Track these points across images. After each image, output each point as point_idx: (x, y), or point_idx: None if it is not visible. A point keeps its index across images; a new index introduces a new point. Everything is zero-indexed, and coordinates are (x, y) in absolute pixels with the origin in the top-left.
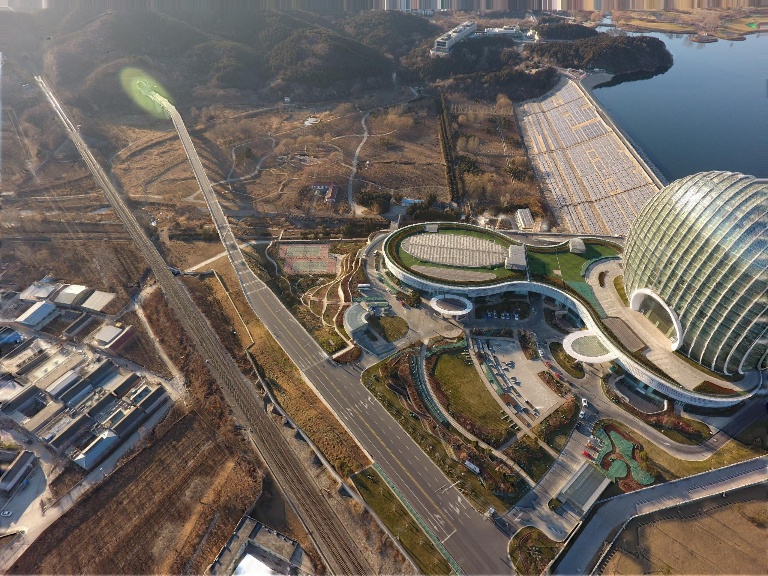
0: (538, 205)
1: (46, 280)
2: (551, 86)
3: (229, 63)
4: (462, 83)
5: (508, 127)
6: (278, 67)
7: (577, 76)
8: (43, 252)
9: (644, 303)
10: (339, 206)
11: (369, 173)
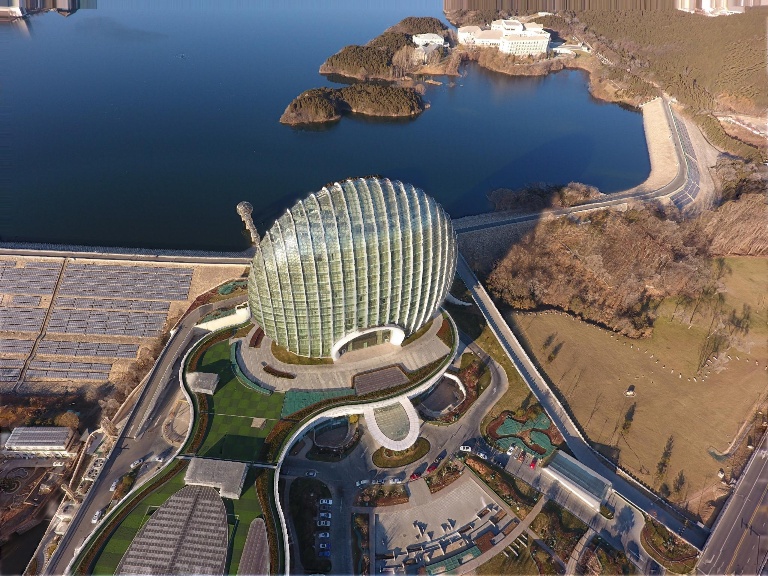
0: None
1: None
2: None
3: None
4: None
5: None
6: None
7: None
8: None
9: None
10: None
11: None
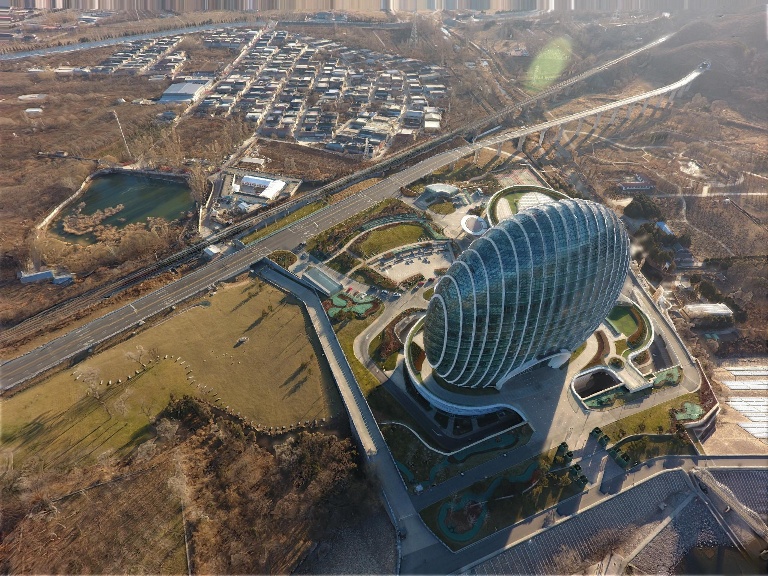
0: None
1: (441, 109)
2: None
3: None
4: None
5: None
6: None
7: None
8: (465, 102)
9: None
10: (618, 192)
11: (705, 204)
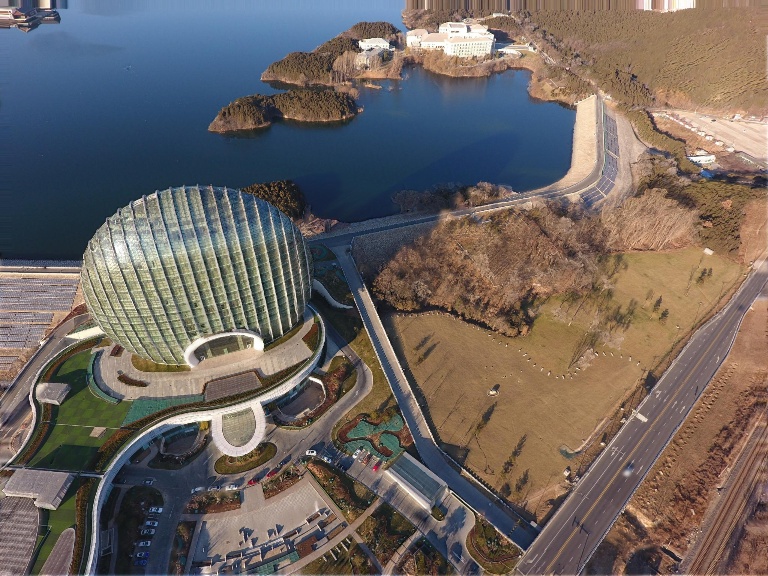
0: None
1: None
2: None
3: None
4: None
5: None
6: None
7: None
8: None
9: (196, 352)
10: None
11: None
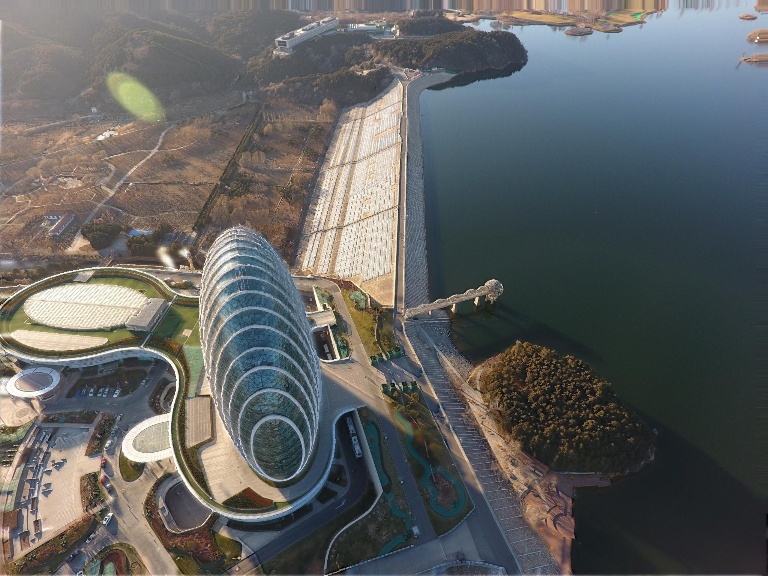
0: (285, 232)
1: None
2: (382, 88)
3: (39, 70)
4: (291, 87)
5: (316, 137)
6: (97, 73)
7: (409, 77)
8: None
9: None
10: (59, 241)
11: (125, 197)
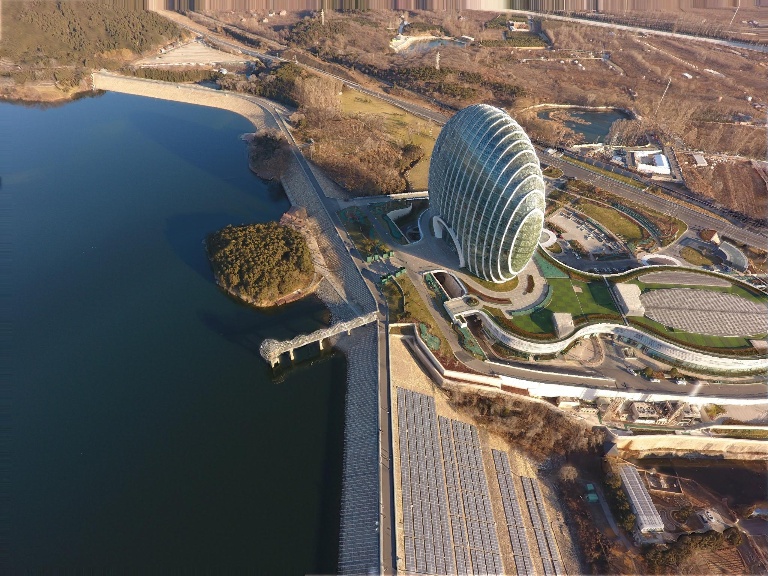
0: None
1: None
2: None
3: None
4: None
5: None
6: None
7: None
8: None
9: None
10: None
11: None
